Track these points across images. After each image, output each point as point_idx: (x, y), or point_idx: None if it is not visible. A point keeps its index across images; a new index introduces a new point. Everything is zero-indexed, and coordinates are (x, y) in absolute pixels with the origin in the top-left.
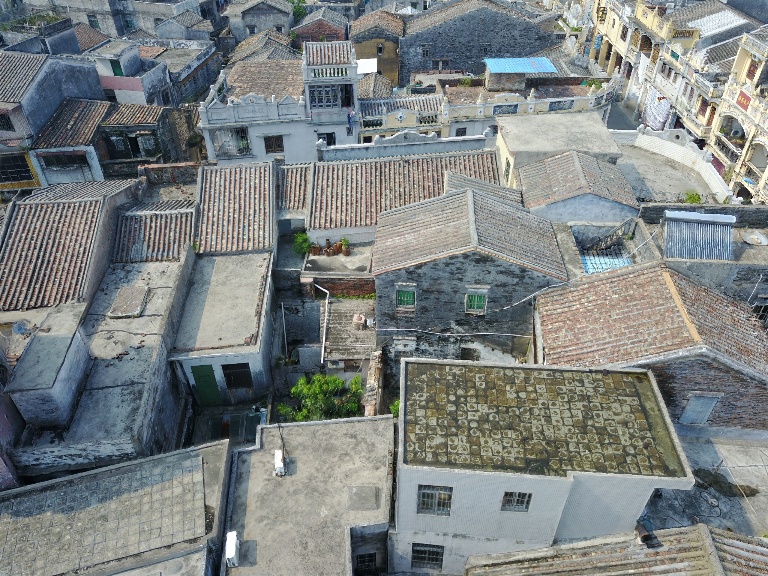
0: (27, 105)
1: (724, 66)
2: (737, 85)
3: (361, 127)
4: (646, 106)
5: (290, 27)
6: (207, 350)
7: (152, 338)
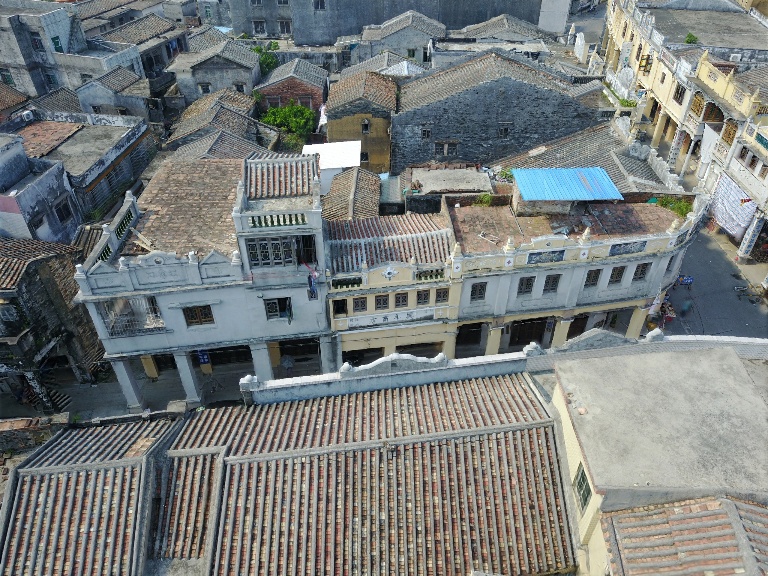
0: None
1: None
2: None
3: (330, 288)
4: (715, 197)
5: (254, 85)
6: None
7: None
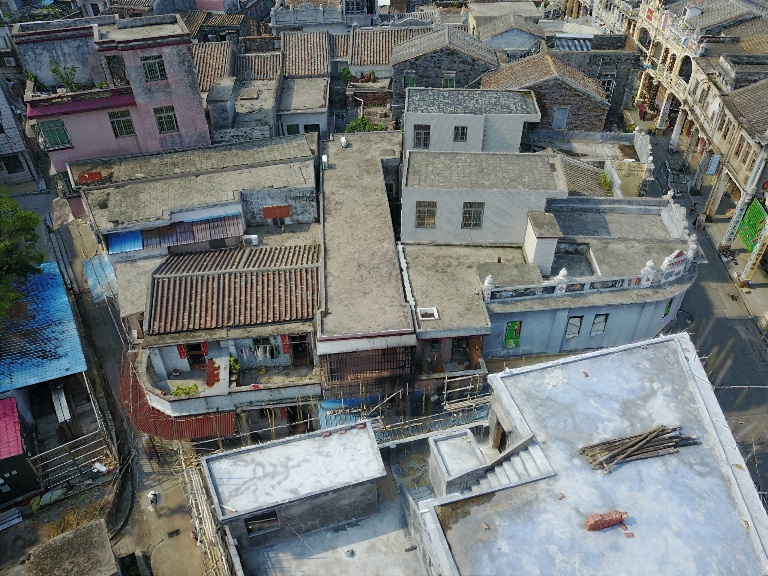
0: (156, 9)
1: None
2: (647, 5)
3: None
4: None
5: None
6: (298, 110)
7: (266, 106)
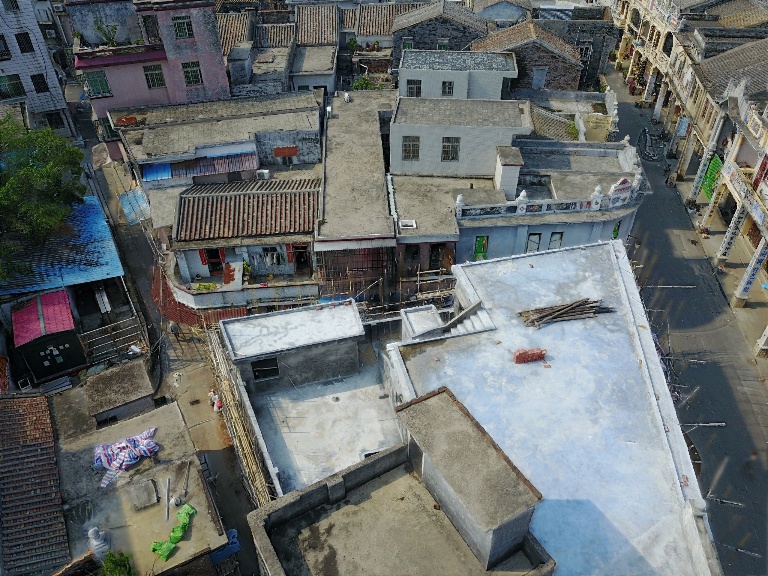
0: None
1: None
2: None
3: None
4: None
5: None
6: (308, 72)
7: (280, 69)
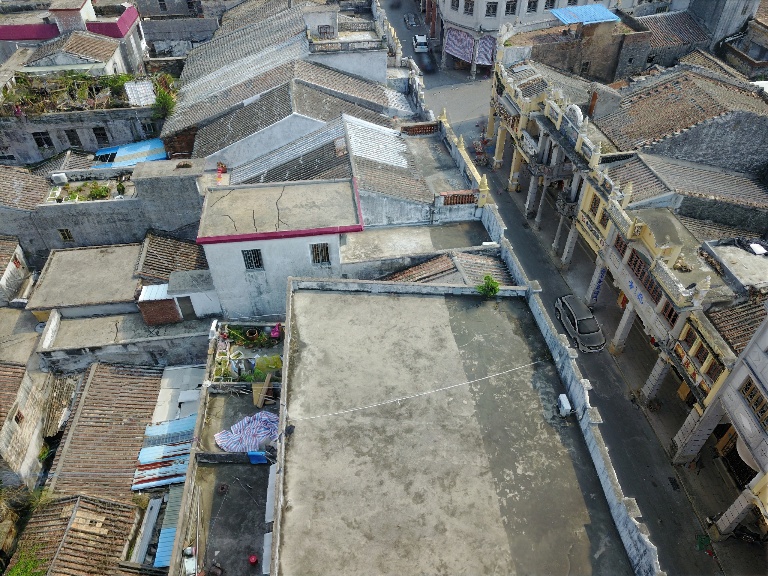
0: None
1: (384, 100)
2: None
3: None
4: None
5: None
6: None
7: None
